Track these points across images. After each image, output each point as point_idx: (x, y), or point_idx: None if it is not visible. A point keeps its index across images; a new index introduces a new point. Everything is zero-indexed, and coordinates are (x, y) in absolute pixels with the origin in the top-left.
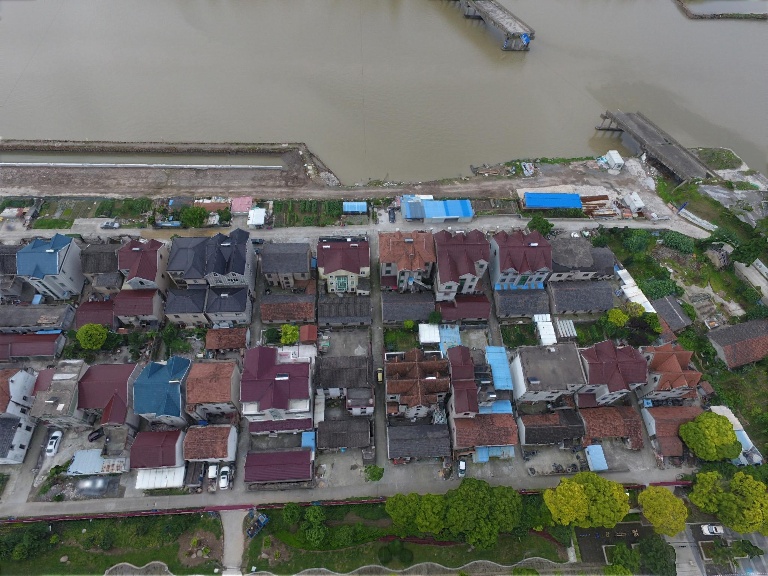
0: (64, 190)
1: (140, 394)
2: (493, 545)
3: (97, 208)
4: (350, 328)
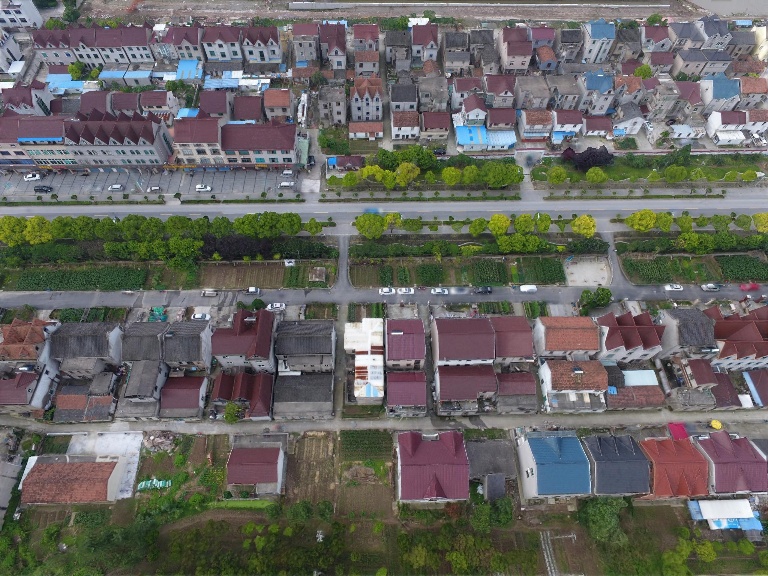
0: (535, 18)
1: (716, 87)
2: None
3: (569, 25)
4: None
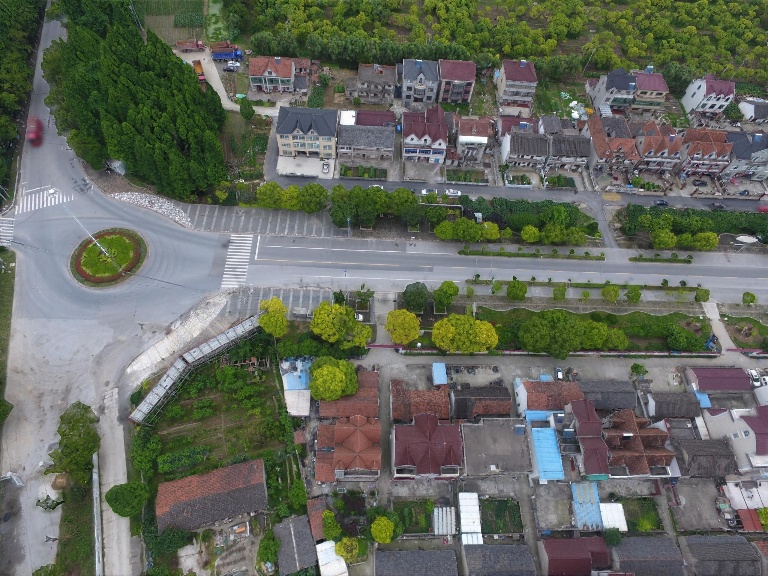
0: None
1: None
2: (542, 313)
3: None
4: (702, 532)
